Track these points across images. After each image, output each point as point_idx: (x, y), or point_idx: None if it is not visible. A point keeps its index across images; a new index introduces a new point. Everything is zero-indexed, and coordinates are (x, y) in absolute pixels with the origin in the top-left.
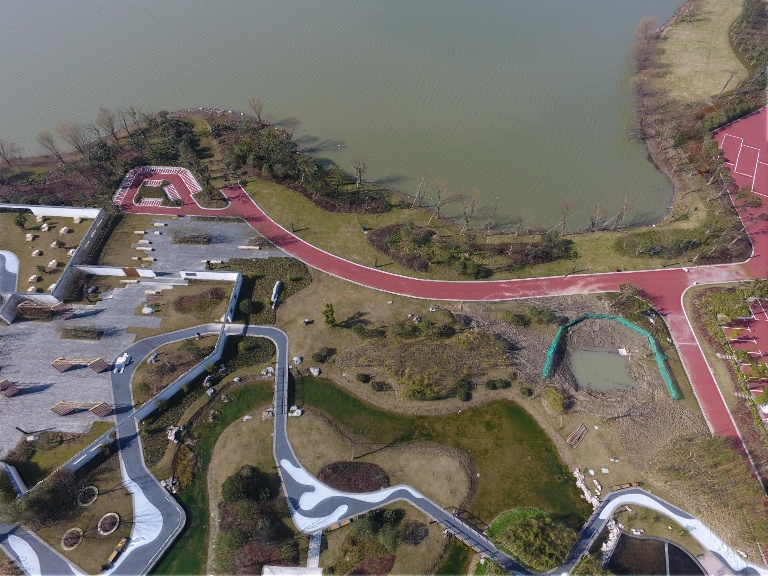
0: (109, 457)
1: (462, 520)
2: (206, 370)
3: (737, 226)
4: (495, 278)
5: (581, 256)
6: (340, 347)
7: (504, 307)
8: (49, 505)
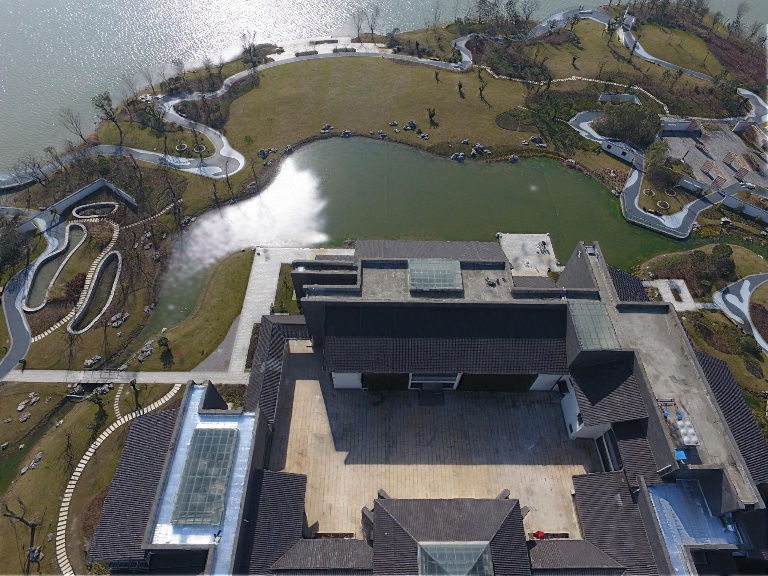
0: (694, 195)
1: None
2: None
3: None
4: None
5: None
6: None
7: None
8: (661, 177)
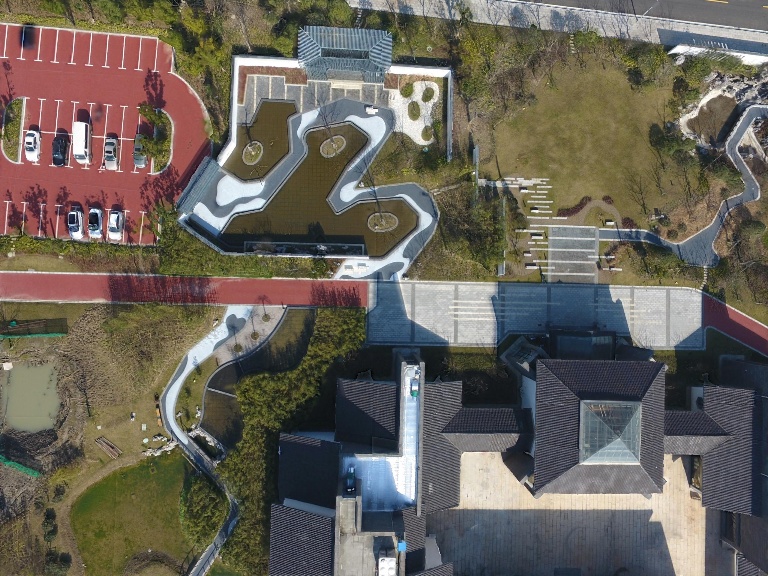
0: None
1: (189, 571)
2: None
3: None
4: None
5: None
6: None
7: None
8: None
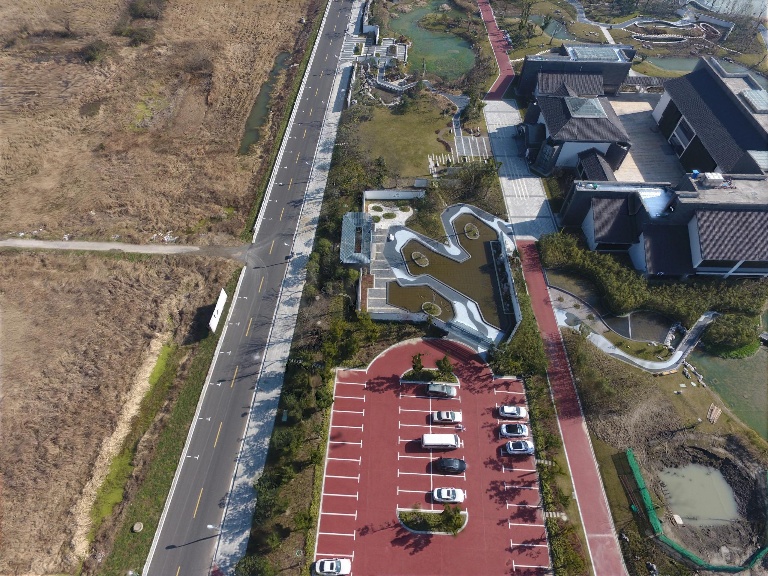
0: None
1: None
2: None
3: None
4: None
5: None
6: None
7: None
8: None
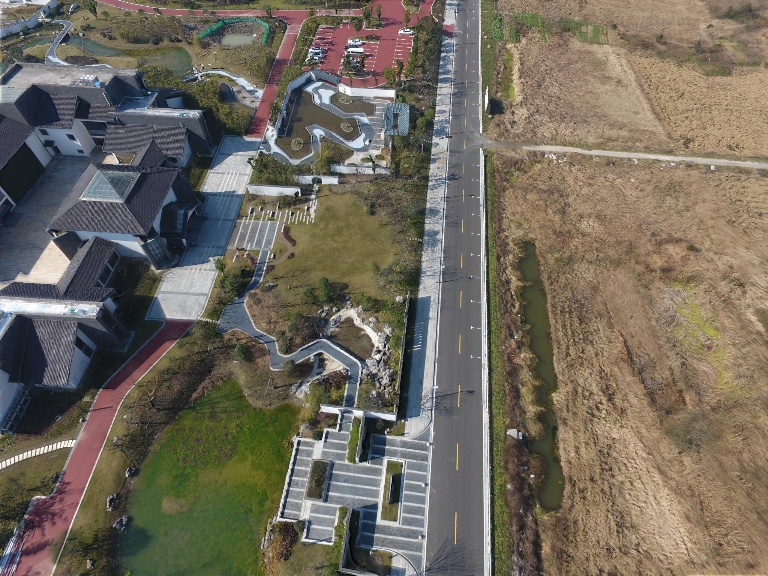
0: None
1: None
2: (22, 29)
3: None
4: (202, 9)
5: (260, 3)
6: (98, 26)
7: (199, 18)
8: None
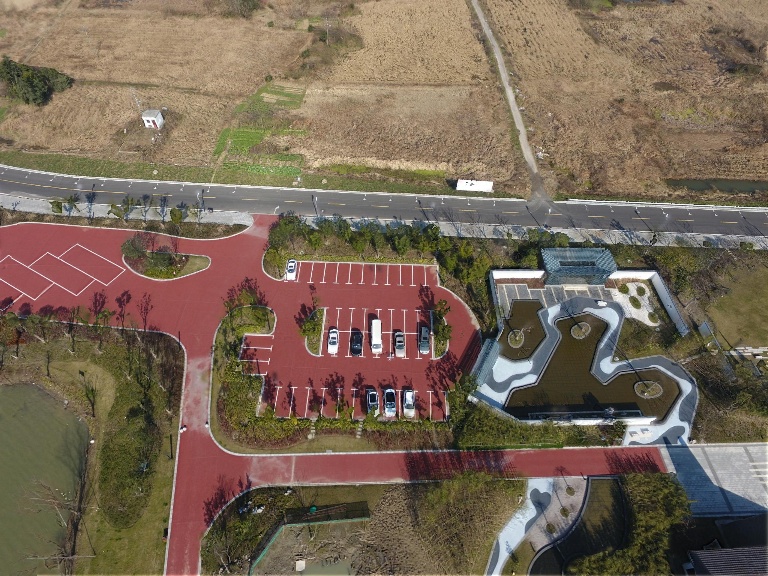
0: None
1: None
2: None
3: (128, 338)
4: None
5: None
6: None
7: None
8: None
